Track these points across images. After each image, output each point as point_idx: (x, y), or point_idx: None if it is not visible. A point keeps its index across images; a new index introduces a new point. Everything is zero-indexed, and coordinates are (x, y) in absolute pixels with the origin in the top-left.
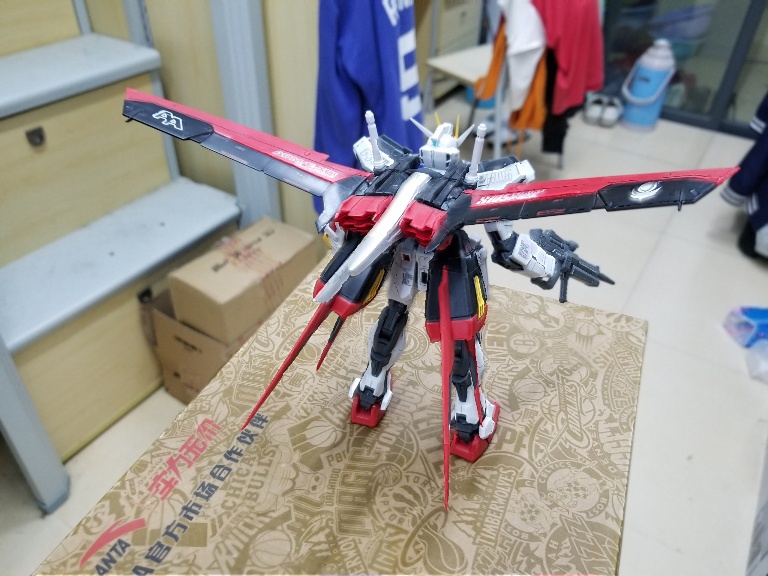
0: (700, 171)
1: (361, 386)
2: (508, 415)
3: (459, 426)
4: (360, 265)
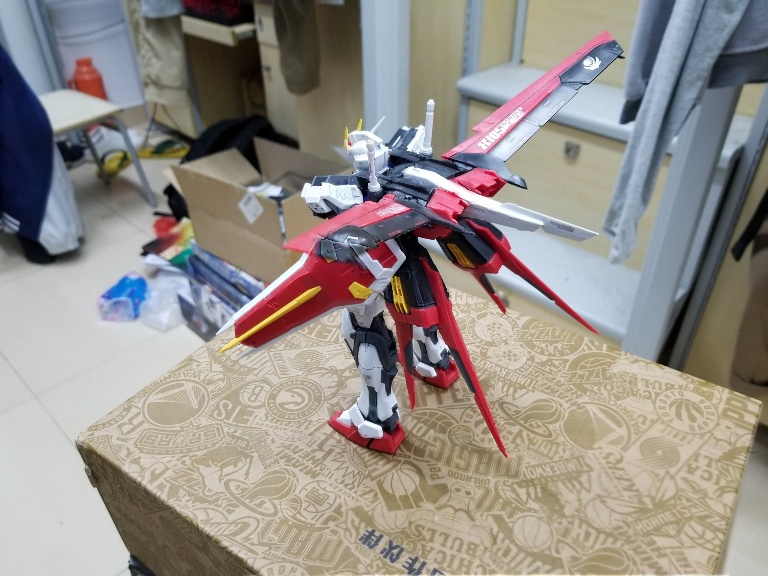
0: (594, 43)
1: (387, 414)
2: None
3: (443, 362)
4: None
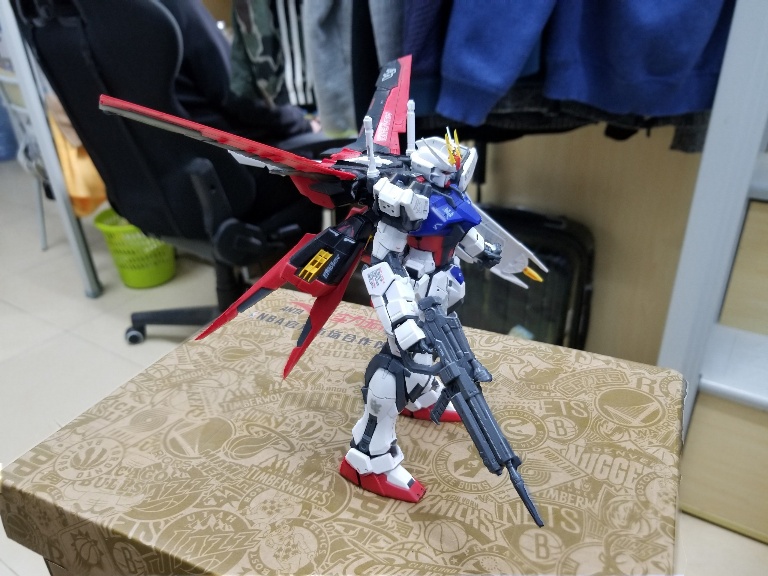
0: None
1: None
2: (403, 509)
3: None
4: None
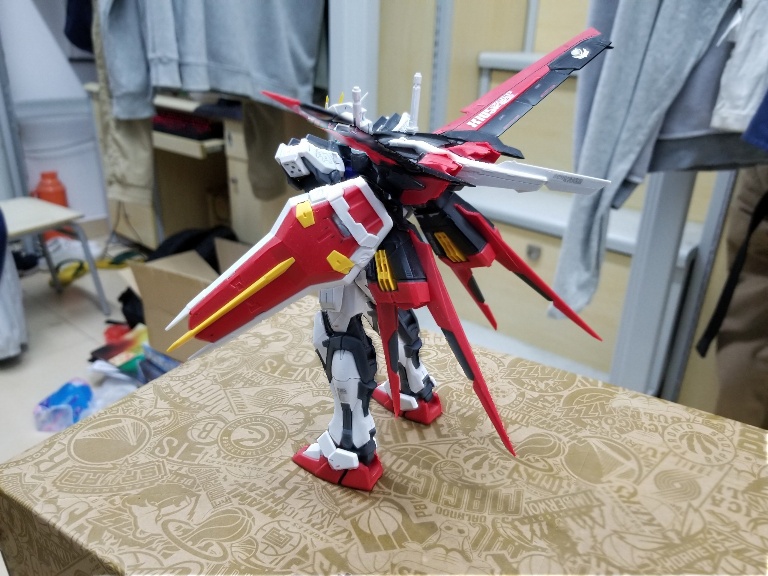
0: (579, 38)
1: (364, 439)
2: None
3: (425, 391)
4: None
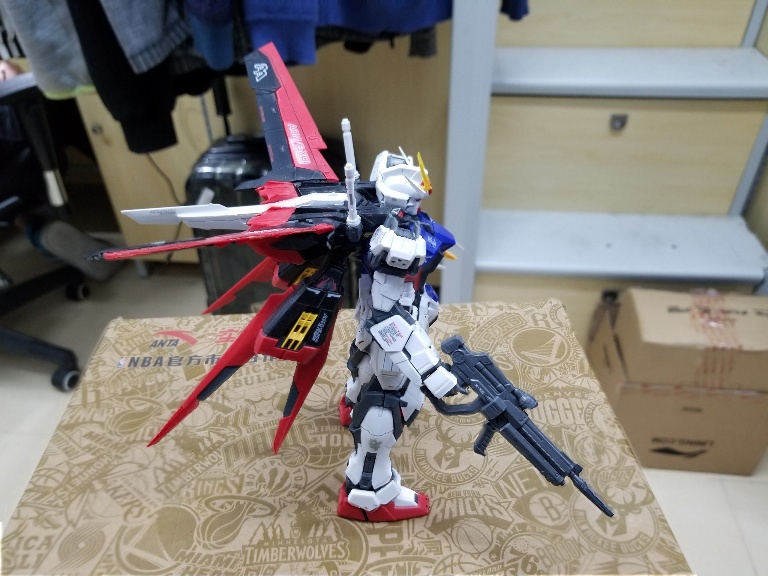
0: None
1: None
2: (420, 526)
3: None
4: (190, 219)
